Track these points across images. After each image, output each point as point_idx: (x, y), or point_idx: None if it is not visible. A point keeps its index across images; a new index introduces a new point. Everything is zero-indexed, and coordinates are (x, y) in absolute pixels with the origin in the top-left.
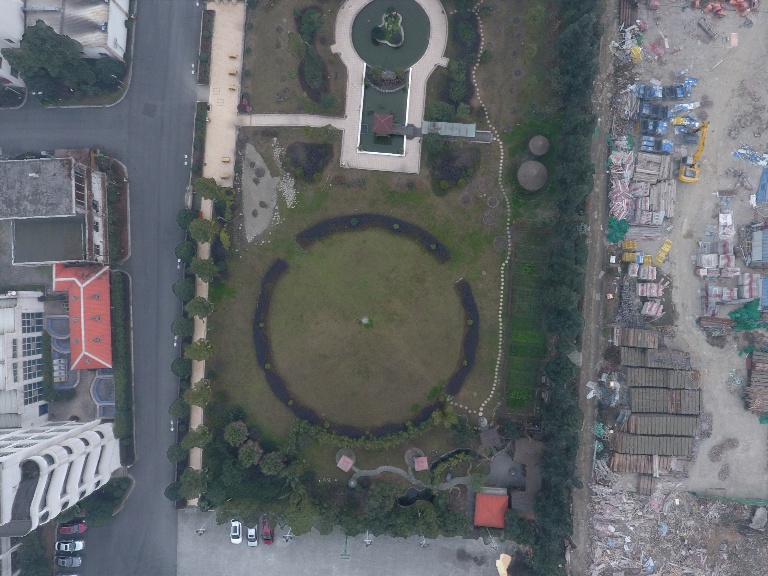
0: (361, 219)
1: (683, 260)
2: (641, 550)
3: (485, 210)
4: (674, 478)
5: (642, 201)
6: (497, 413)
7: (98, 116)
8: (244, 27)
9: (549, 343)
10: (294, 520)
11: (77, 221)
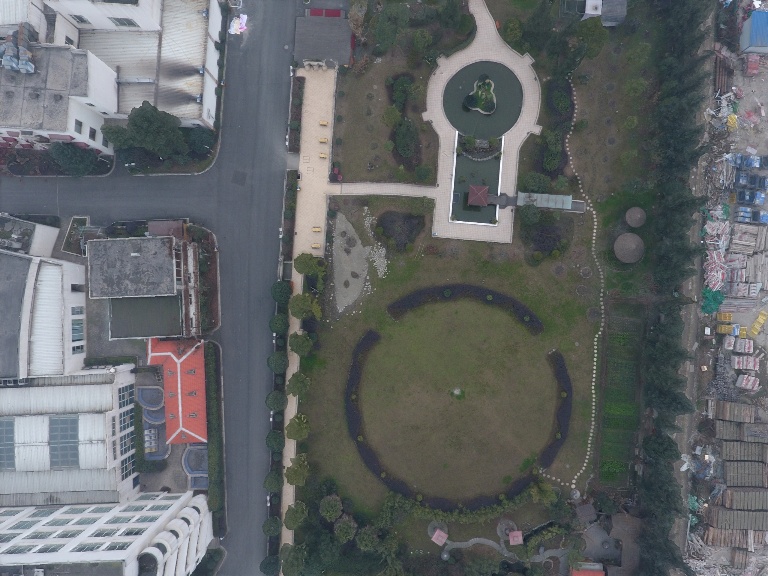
0: (454, 290)
1: None
2: None
3: (578, 280)
4: None
5: (738, 273)
6: (590, 485)
7: (187, 184)
8: (335, 94)
9: (642, 415)
10: None
11: (173, 296)
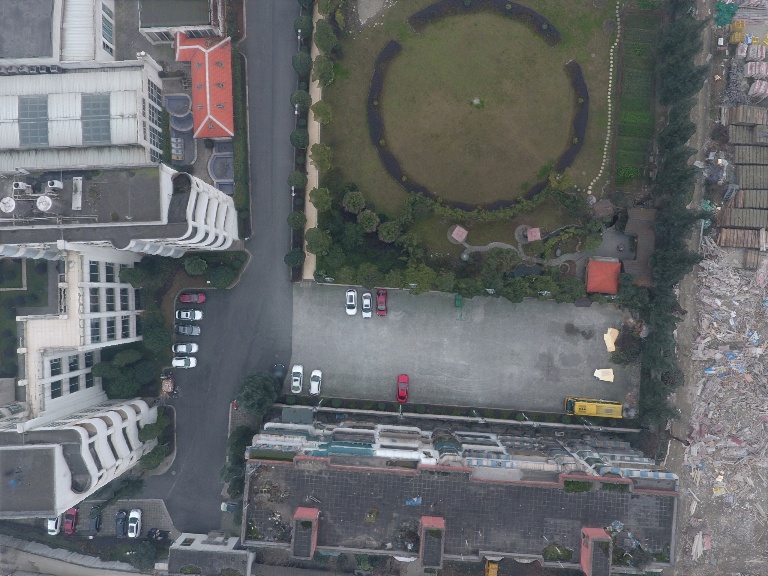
0: None
1: None
2: (746, 324)
3: None
4: None
5: None
6: (605, 192)
7: None
8: None
9: (657, 124)
10: (416, 276)
11: None
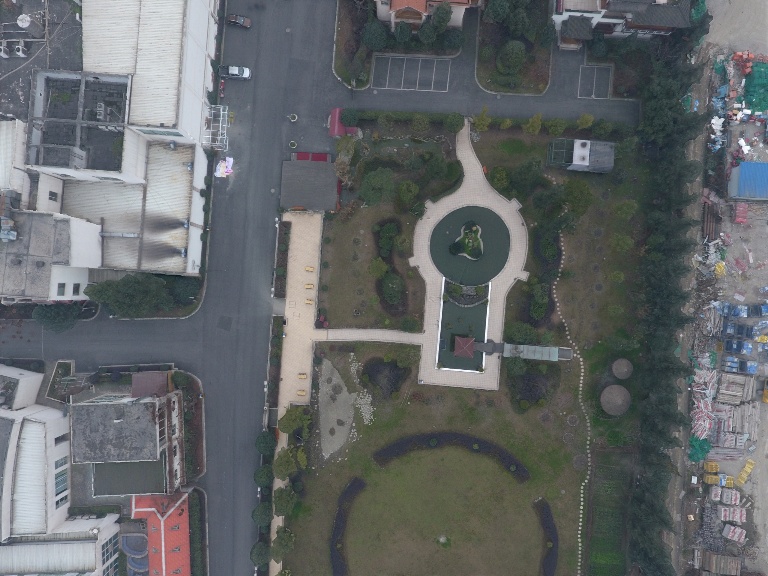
0: (440, 439)
1: (765, 480)
2: None
3: (565, 428)
4: None
5: (725, 422)
6: None
7: (172, 328)
8: (321, 240)
9: (629, 564)
10: None
11: None
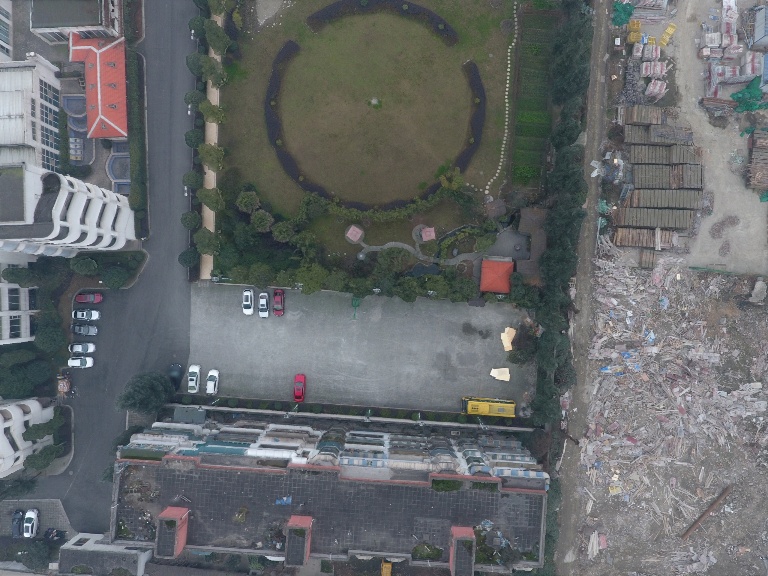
0: (371, 0)
1: (687, 43)
2: (643, 324)
3: None
4: (676, 254)
5: None
6: (503, 191)
7: None
8: None
9: (554, 123)
10: (305, 276)
11: None
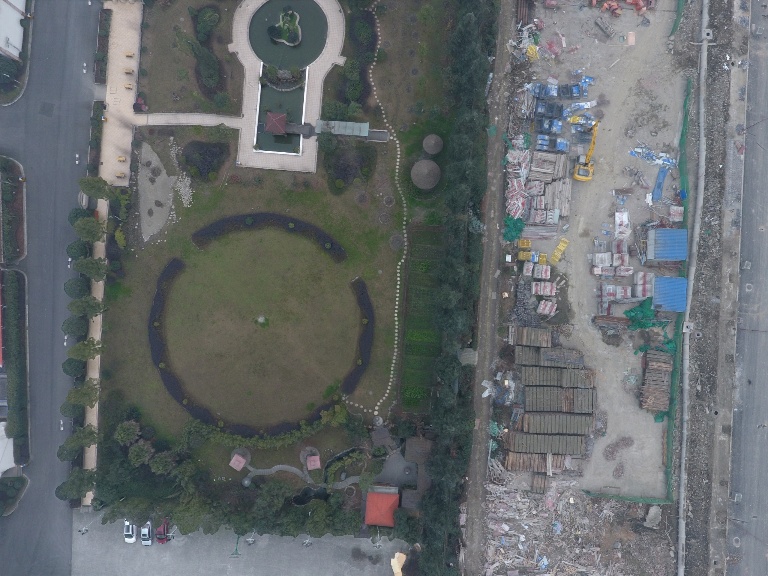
0: (256, 218)
1: (579, 259)
2: (535, 549)
3: (381, 209)
4: (569, 477)
5: (537, 200)
6: (392, 412)
7: None
8: (141, 26)
9: None
10: (180, 519)
11: None
